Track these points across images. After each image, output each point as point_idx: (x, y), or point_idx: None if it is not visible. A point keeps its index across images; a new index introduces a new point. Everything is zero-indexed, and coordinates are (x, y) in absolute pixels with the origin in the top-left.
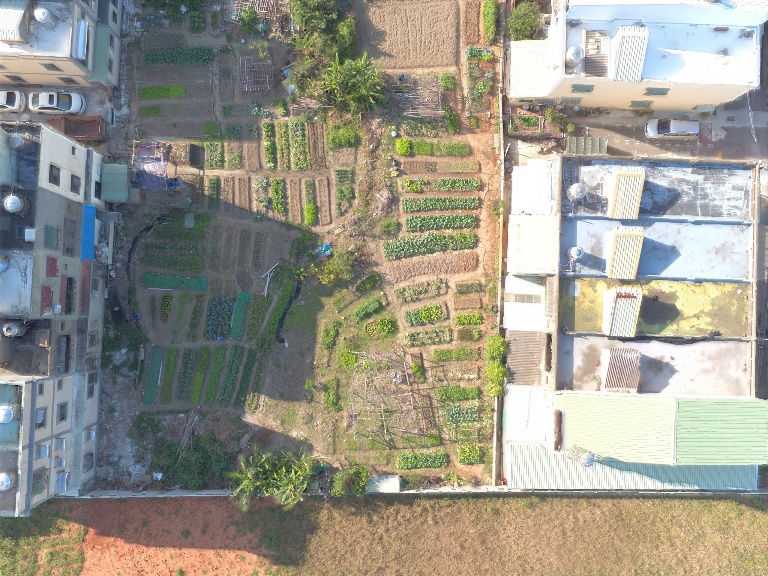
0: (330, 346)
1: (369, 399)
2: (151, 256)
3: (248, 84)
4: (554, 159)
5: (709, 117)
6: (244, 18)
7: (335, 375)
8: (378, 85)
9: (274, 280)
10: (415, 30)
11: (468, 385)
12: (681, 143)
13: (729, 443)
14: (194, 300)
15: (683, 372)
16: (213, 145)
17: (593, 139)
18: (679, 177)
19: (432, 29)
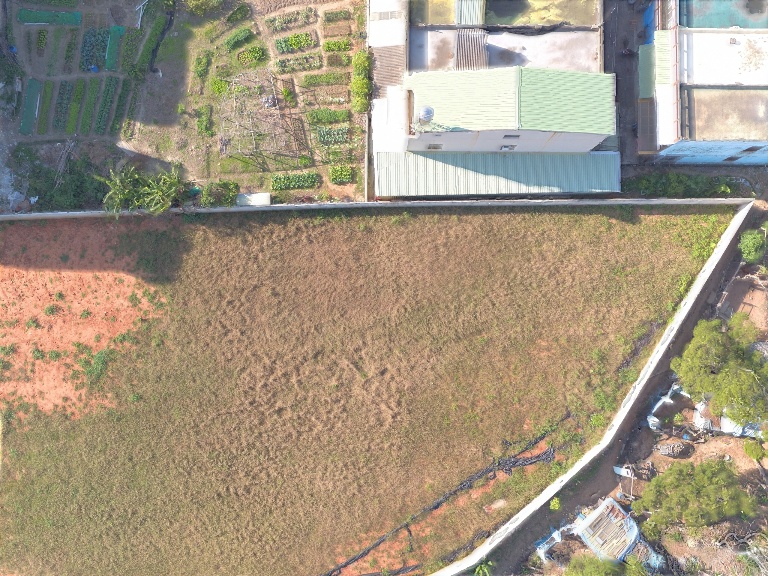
0: (203, 74)
1: None
2: None
3: None
4: None
5: None
6: None
7: (209, 102)
8: None
9: (147, 13)
10: None
11: (339, 108)
12: None
13: (574, 111)
14: (69, 34)
15: (536, 62)
16: None
17: None
18: None
19: None
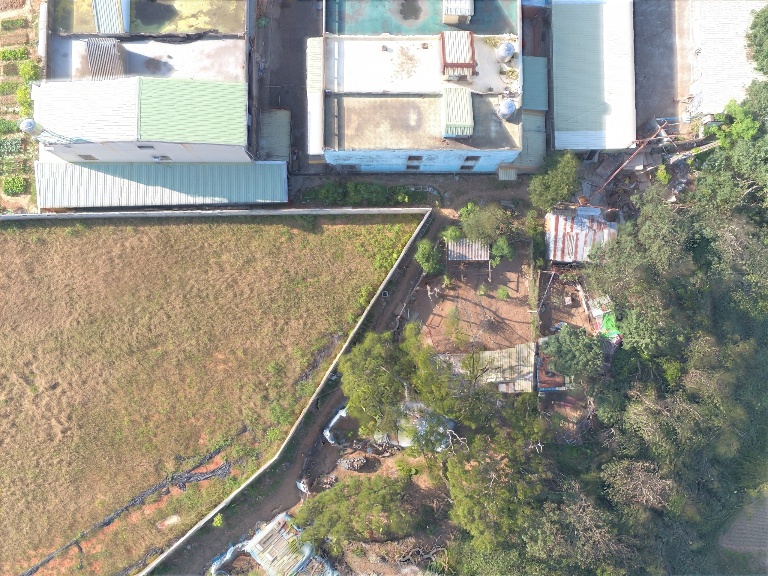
0: None
1: None
2: None
3: None
4: None
5: None
6: None
7: None
8: None
9: None
10: None
11: (14, 118)
12: None
13: (201, 122)
14: None
15: (182, 71)
16: None
17: None
18: None
19: None
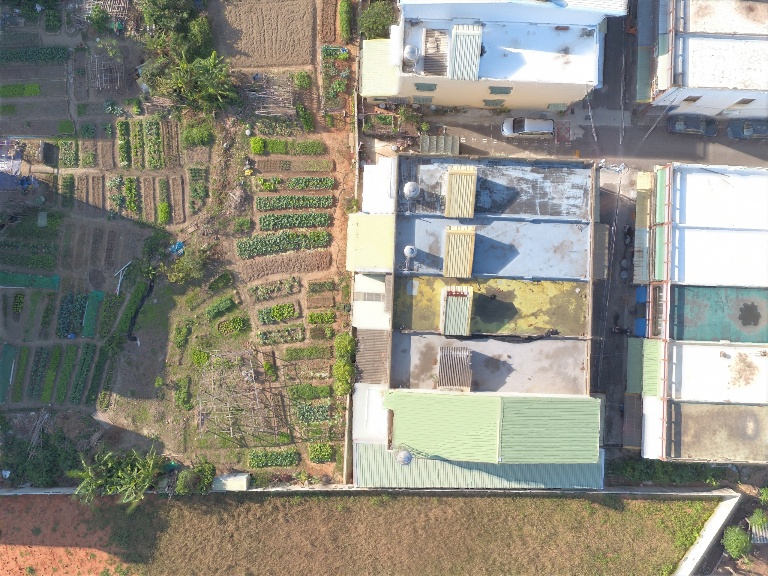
0: (182, 344)
1: (215, 397)
2: (3, 254)
3: (98, 83)
4: (394, 158)
5: (567, 116)
6: (92, 17)
7: (187, 373)
8: (226, 84)
9: (126, 278)
10: (271, 29)
11: (320, 384)
12: (538, 142)
13: (557, 442)
14: (46, 298)
15: (520, 371)
16: (67, 144)
17: (446, 138)
18: (518, 176)
19: (288, 28)
